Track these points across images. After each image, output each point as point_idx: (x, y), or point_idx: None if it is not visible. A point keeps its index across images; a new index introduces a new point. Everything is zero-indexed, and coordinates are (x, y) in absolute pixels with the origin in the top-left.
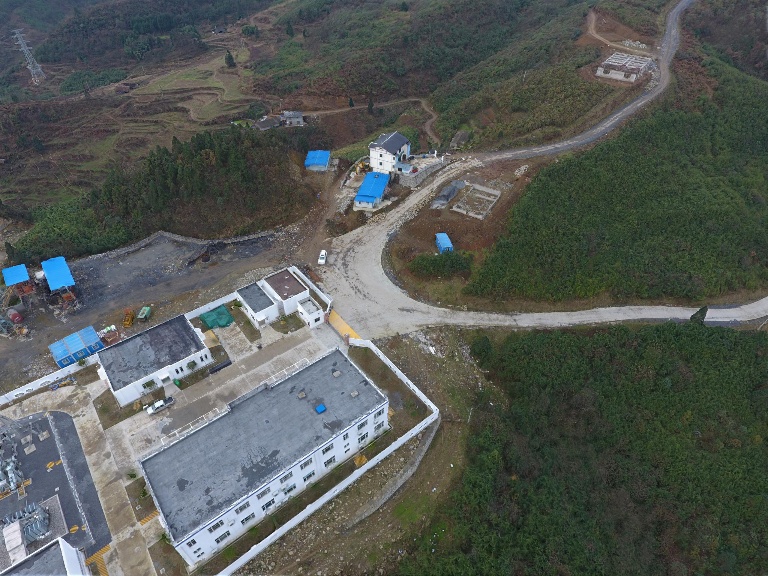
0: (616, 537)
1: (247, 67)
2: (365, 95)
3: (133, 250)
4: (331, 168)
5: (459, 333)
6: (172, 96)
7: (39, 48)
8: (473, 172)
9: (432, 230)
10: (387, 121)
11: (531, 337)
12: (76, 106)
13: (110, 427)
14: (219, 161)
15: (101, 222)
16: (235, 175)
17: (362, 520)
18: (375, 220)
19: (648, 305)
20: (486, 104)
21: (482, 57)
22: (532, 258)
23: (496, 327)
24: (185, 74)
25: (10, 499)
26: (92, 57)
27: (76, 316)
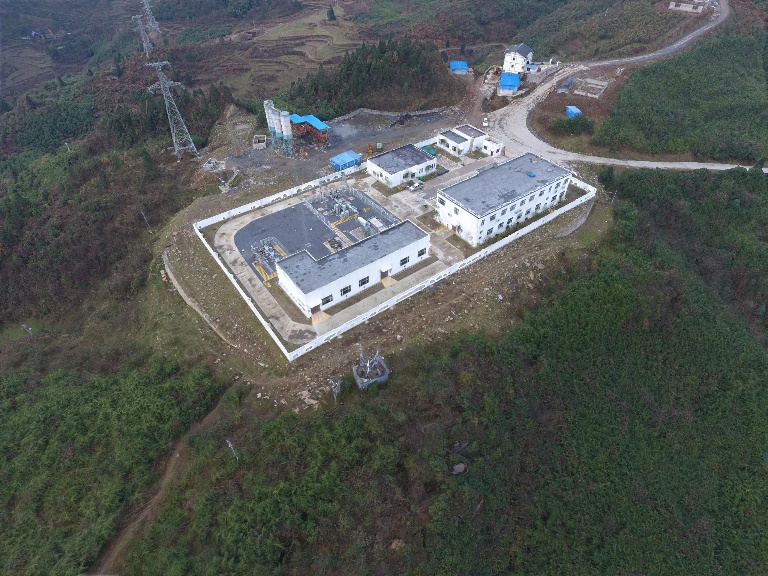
0: (705, 286)
1: (347, 19)
2: (457, 39)
3: (347, 119)
4: (469, 73)
5: (590, 167)
6: (289, 42)
7: (154, 8)
8: (582, 73)
9: (562, 105)
10: (477, 60)
11: (641, 170)
12: (213, 49)
13: (390, 196)
14: (403, 58)
15: (311, 106)
16: (415, 68)
17: (561, 237)
18: (515, 102)
19: (719, 163)
20: (573, 37)
21: (554, 8)
22: (636, 125)
23: (615, 165)
24: (293, 26)
25: (351, 221)
26: (199, 16)
27: (331, 150)
